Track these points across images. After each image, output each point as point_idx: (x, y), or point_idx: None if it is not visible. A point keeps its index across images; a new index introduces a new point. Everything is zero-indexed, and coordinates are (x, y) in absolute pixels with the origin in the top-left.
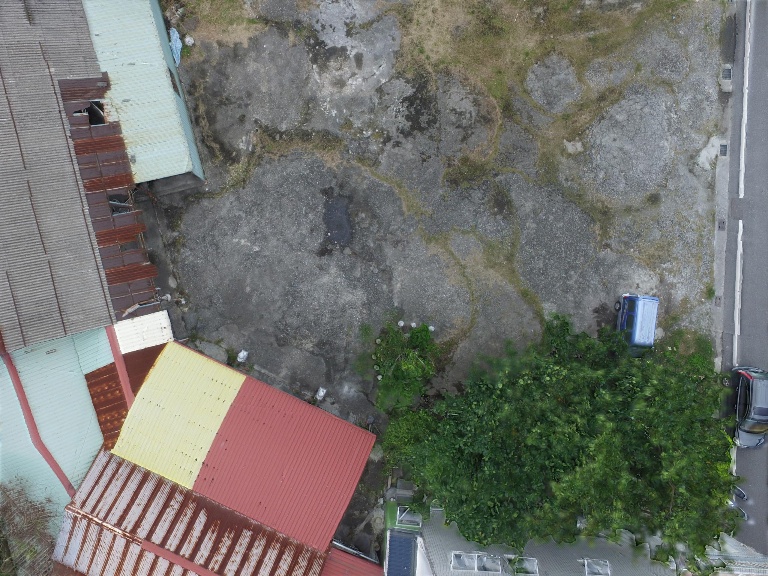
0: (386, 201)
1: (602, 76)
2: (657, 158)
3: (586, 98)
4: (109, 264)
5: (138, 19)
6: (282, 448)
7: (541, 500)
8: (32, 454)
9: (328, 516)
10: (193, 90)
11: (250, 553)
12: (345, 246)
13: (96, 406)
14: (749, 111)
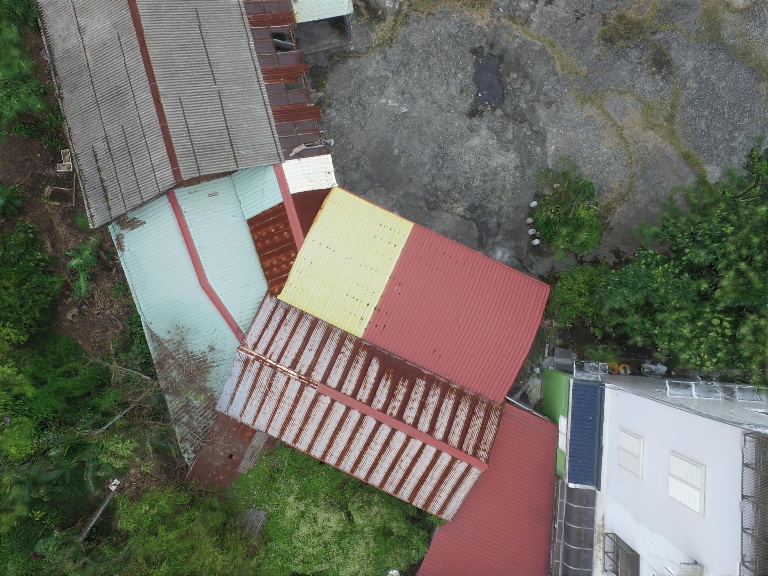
0: (539, 60)
1: None
2: None
3: None
4: (275, 102)
5: None
6: (457, 294)
7: None
8: (198, 297)
9: (506, 365)
10: None
11: (426, 402)
12: (496, 107)
13: (260, 251)
14: None
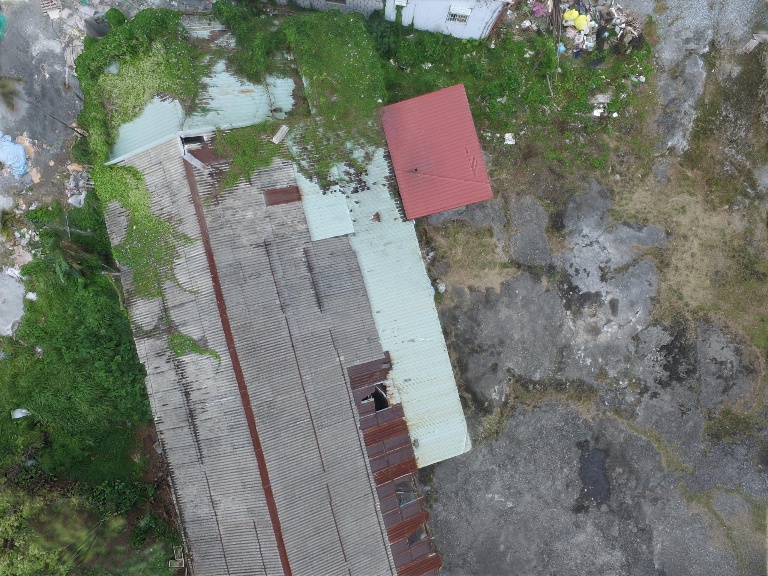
0: (645, 456)
1: None
2: None
3: None
4: (400, 561)
5: (416, 292)
6: None
7: None
8: None
9: None
10: None
11: None
12: (602, 503)
13: None
14: None
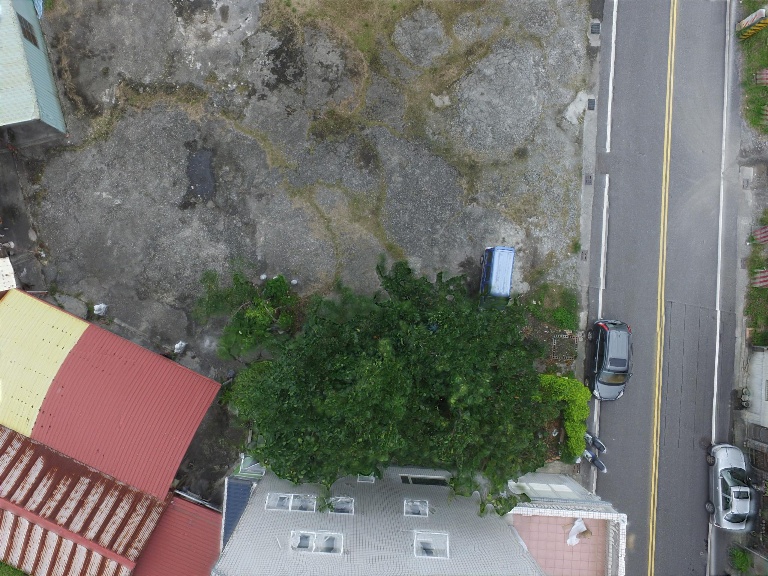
0: (250, 154)
1: (470, 30)
2: (525, 112)
3: (454, 52)
4: None
5: None
6: (120, 395)
7: (333, 431)
8: None
9: (166, 464)
10: (56, 42)
11: (85, 501)
12: (208, 199)
13: None
14: (617, 65)
